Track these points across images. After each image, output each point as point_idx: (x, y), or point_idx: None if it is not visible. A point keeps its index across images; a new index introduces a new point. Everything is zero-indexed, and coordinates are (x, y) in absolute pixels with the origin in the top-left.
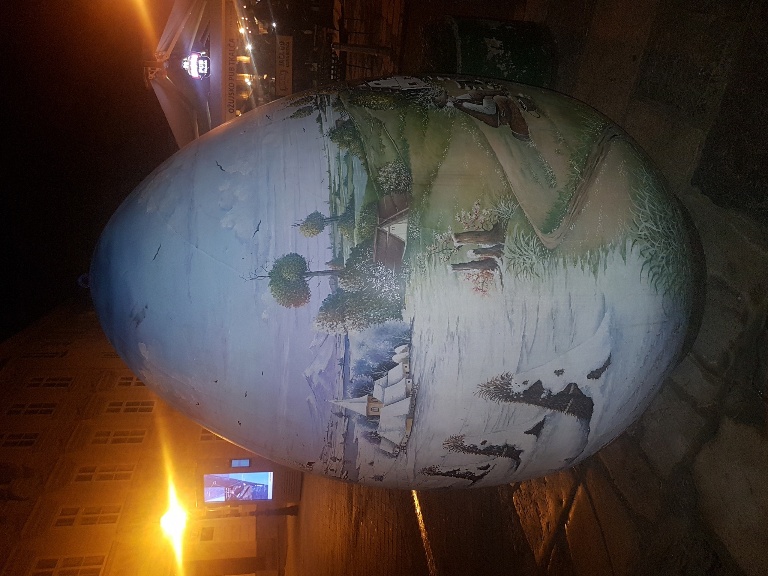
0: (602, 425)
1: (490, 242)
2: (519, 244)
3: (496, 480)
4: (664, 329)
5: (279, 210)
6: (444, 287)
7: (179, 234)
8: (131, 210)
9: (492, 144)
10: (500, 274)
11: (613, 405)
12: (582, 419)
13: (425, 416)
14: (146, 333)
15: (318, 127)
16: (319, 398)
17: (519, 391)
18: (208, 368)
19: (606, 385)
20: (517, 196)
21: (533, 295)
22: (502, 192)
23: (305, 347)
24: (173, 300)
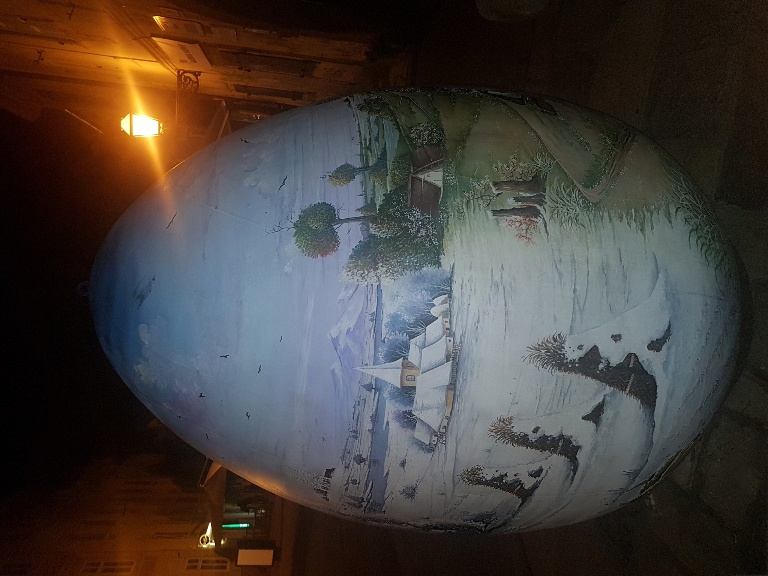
0: (667, 420)
1: (530, 191)
2: (561, 195)
3: (548, 504)
4: (721, 307)
5: (307, 165)
6: (485, 233)
7: (197, 200)
8: (146, 196)
9: (522, 115)
10: (544, 222)
11: (678, 392)
12: (645, 406)
13: (468, 388)
14: (150, 311)
15: (346, 104)
16: (346, 366)
17: (574, 358)
18: (218, 340)
19: (668, 362)
20: (553, 154)
21: (581, 246)
22: (538, 149)
23: (332, 302)
24: (185, 266)
